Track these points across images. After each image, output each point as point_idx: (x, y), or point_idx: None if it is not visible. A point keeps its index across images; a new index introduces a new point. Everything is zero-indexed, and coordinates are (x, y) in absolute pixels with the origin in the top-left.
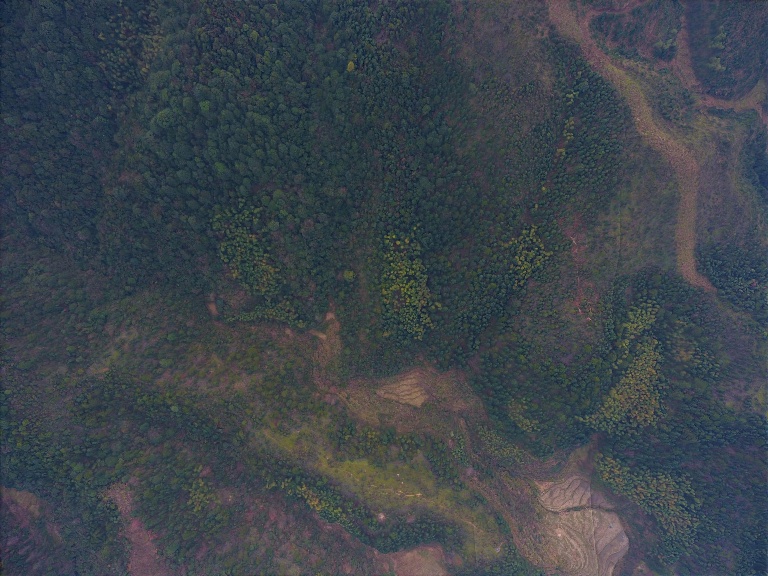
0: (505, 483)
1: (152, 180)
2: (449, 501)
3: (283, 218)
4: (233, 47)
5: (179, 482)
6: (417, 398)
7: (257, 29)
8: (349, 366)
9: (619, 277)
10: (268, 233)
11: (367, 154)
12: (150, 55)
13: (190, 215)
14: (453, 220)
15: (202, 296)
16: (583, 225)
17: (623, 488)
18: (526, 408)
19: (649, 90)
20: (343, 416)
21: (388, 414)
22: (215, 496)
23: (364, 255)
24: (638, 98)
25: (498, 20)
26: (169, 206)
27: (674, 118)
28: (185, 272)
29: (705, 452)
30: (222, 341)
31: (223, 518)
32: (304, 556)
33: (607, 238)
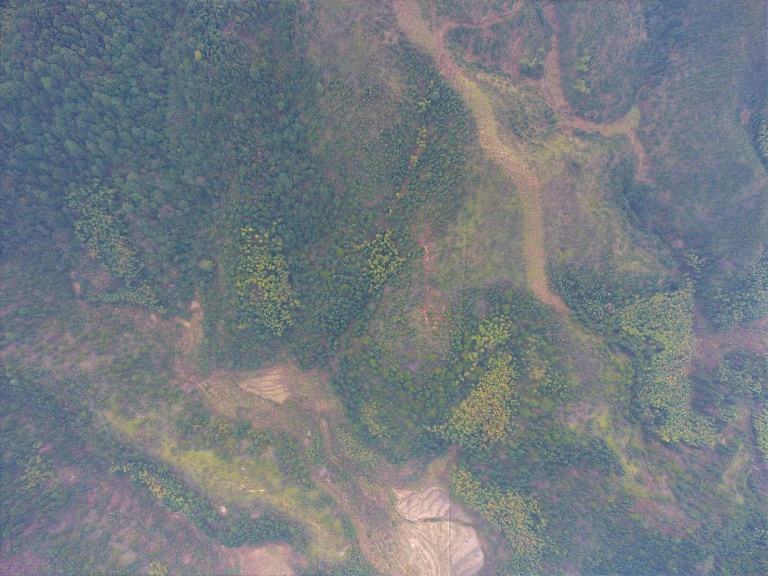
0: (361, 488)
1: None
2: (294, 500)
3: (138, 201)
4: (78, 26)
5: (14, 456)
6: (280, 394)
7: (106, 11)
8: (209, 356)
9: (467, 289)
10: (125, 215)
11: (221, 145)
12: (4, 28)
13: (44, 190)
14: (312, 218)
15: (67, 274)
16: (434, 234)
17: (474, 502)
18: (375, 413)
19: (499, 105)
20: (197, 406)
21: (247, 408)
22: (54, 474)
23: (221, 246)
24: (485, 111)
25: (339, 21)
26: (21, 179)
27: (527, 135)
28: (49, 248)
29: (551, 472)
30: (80, 320)
31: (59, 497)
32: (142, 543)
33: (454, 248)
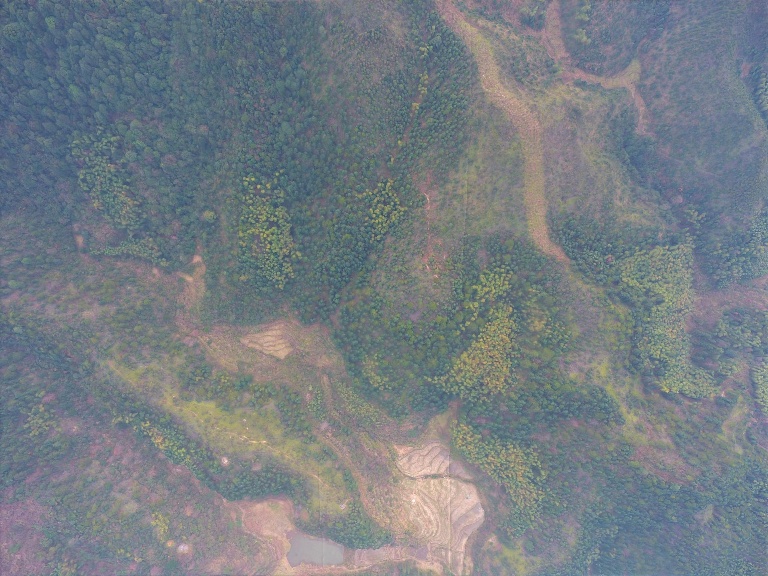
0: (362, 443)
1: (3, 96)
2: (296, 452)
3: (141, 150)
4: None
5: (17, 404)
6: (281, 350)
7: None
8: (211, 310)
9: (468, 237)
10: (128, 165)
11: (224, 91)
12: None
13: (47, 138)
14: (314, 169)
15: (70, 227)
16: (435, 182)
17: (475, 456)
18: (377, 364)
19: (501, 50)
20: (199, 359)
21: (249, 363)
22: (56, 424)
23: (224, 196)
24: (486, 55)
25: None
26: (25, 126)
27: (528, 82)
28: (52, 200)
29: (552, 424)
30: (83, 272)
31: (61, 446)
32: (144, 494)
33: (455, 195)
